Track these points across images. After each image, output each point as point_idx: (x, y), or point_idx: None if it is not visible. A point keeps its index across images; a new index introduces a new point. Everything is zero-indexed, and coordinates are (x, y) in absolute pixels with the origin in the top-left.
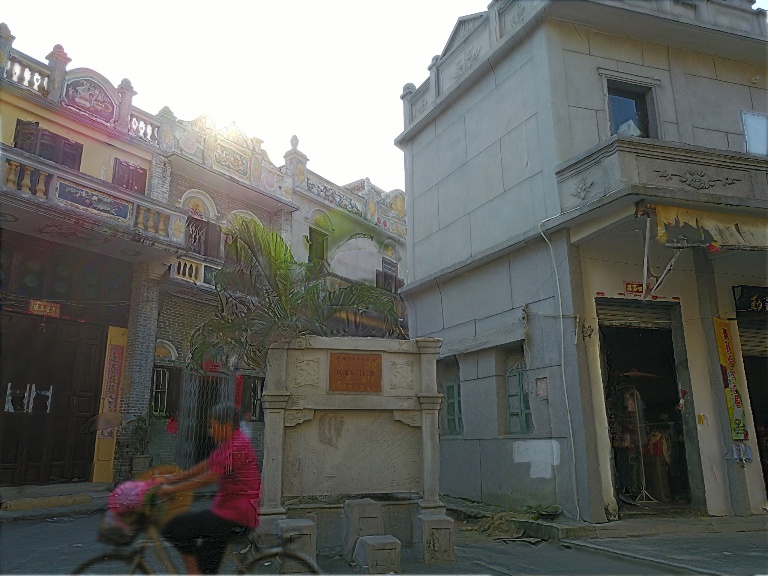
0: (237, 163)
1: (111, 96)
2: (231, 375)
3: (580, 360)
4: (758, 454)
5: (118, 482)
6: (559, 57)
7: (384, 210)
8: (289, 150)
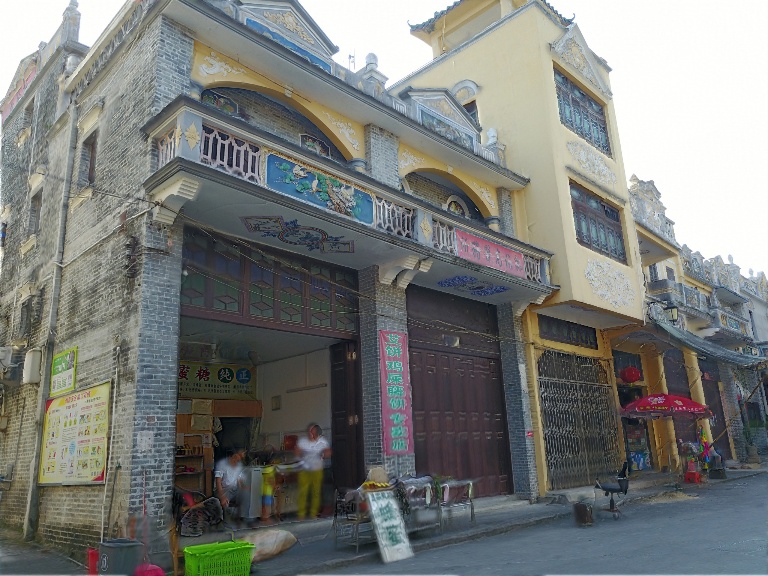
0: (726, 281)
1: (699, 263)
2: (743, 402)
3: None
4: None
5: (743, 459)
6: None
7: (761, 288)
8: (731, 265)
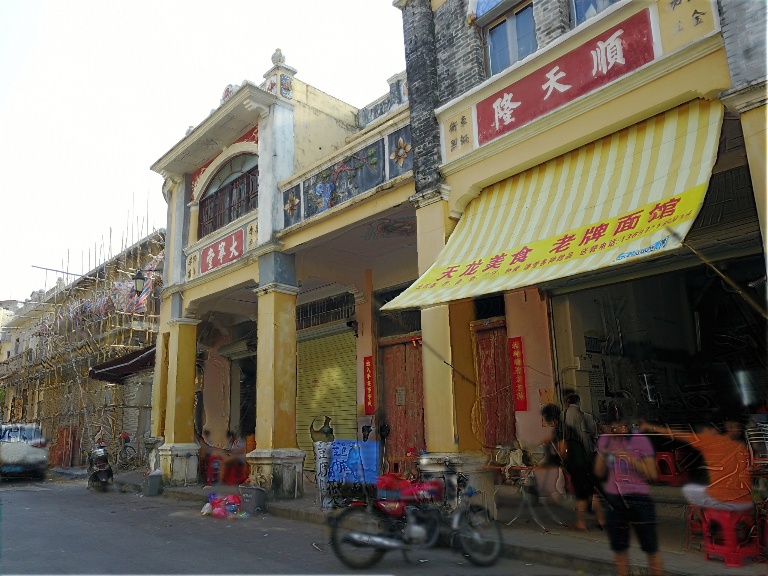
0: None
1: None
2: None
3: (4, 414)
4: (19, 435)
5: None
6: (12, 338)
7: None
8: None
